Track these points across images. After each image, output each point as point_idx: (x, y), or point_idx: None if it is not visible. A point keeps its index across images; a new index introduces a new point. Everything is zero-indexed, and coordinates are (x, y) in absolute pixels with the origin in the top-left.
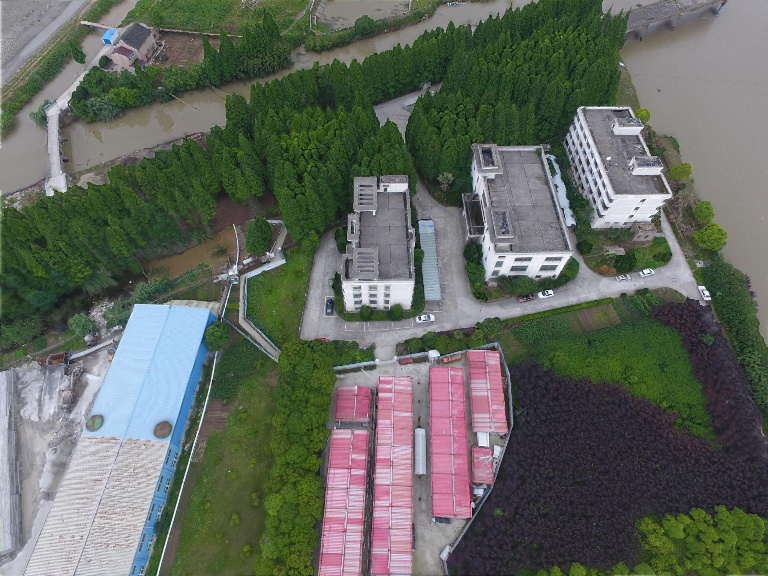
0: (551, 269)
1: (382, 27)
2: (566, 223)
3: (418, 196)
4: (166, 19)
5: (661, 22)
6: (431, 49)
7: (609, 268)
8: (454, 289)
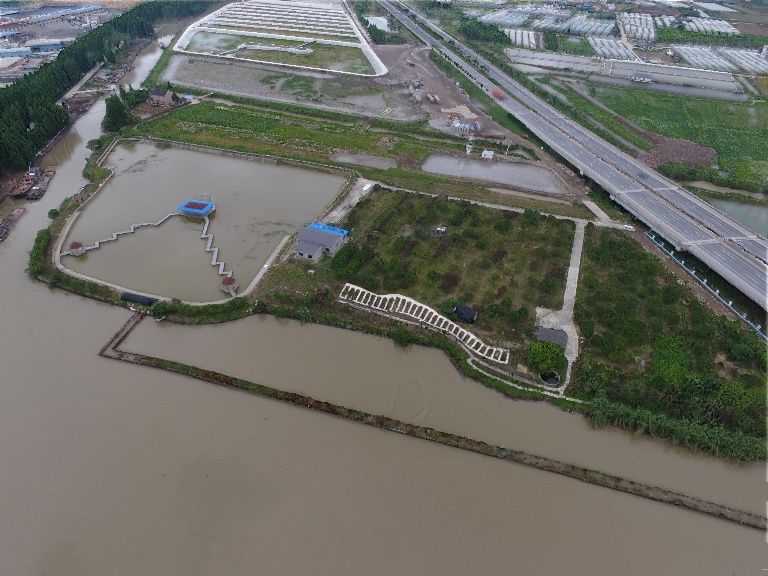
0: None
1: None
2: None
3: None
4: (193, 107)
5: None
6: None
7: None
8: None
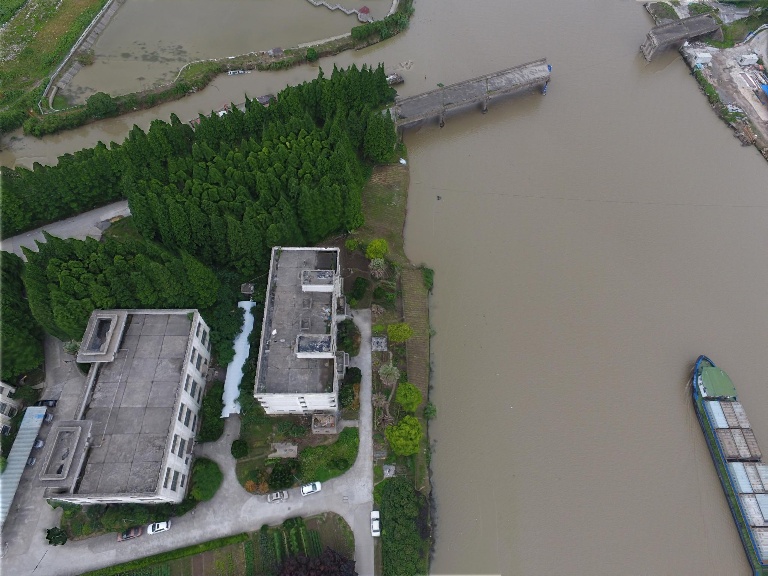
0: (157, 499)
1: (129, 104)
2: (224, 412)
3: (58, 360)
4: None
5: (466, 106)
6: (116, 157)
7: (259, 483)
8: (38, 517)
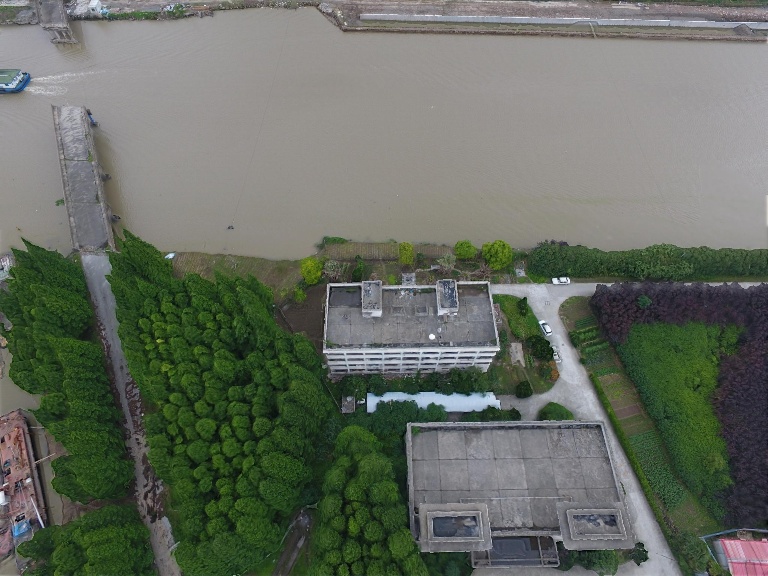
0: None
1: None
2: (495, 406)
3: None
4: None
5: None
6: None
7: None
8: None
